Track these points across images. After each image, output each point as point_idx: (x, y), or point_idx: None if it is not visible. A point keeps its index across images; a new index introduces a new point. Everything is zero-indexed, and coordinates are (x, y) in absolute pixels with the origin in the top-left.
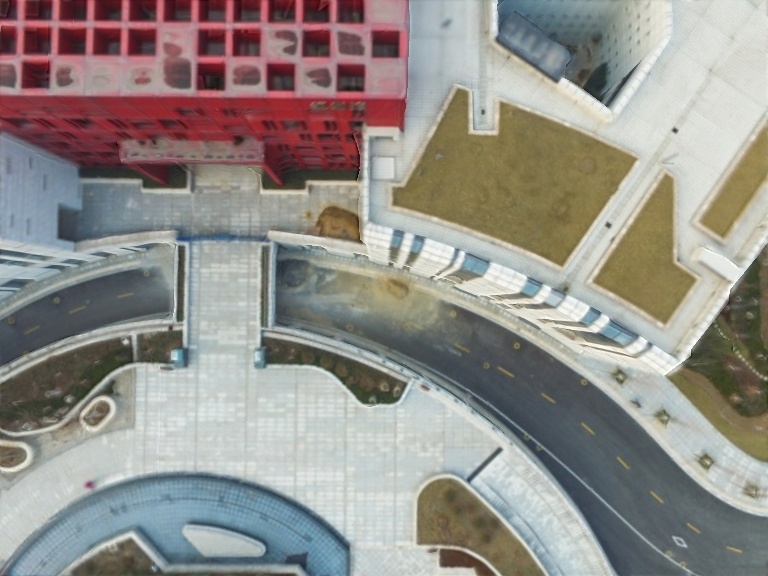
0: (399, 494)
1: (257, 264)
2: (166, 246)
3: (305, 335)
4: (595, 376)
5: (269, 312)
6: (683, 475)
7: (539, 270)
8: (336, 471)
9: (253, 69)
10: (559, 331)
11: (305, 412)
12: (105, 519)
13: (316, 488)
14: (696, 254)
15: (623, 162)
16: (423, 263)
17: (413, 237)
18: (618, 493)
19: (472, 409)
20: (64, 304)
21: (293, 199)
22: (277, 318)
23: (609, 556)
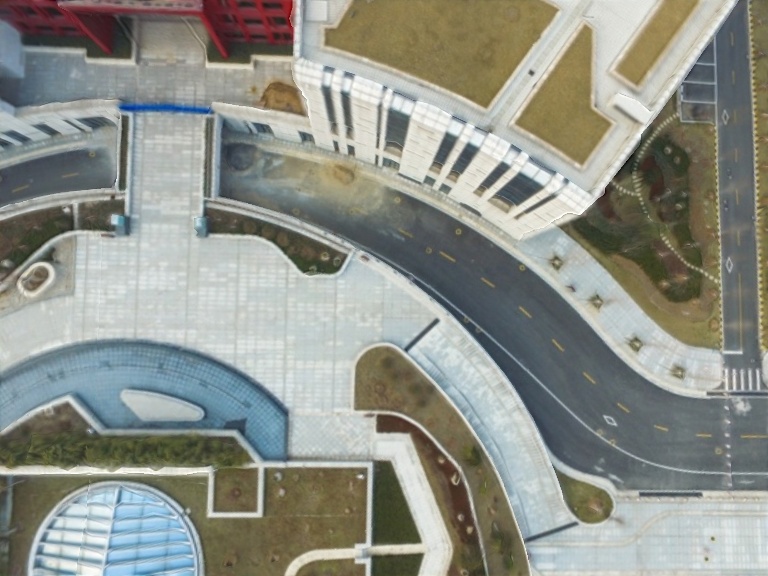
0: (338, 362)
1: (201, 136)
2: (112, 126)
3: (248, 206)
4: (533, 262)
5: (212, 183)
6: (614, 357)
7: (465, 113)
8: (276, 339)
9: None
10: (494, 204)
11: (247, 282)
12: (42, 385)
13: (256, 356)
14: (611, 99)
15: (545, 12)
16: (358, 117)
17: (343, 74)
18: (553, 374)
19: (410, 281)
20: (7, 183)
21: (238, 74)
22: (221, 193)
23: (543, 434)
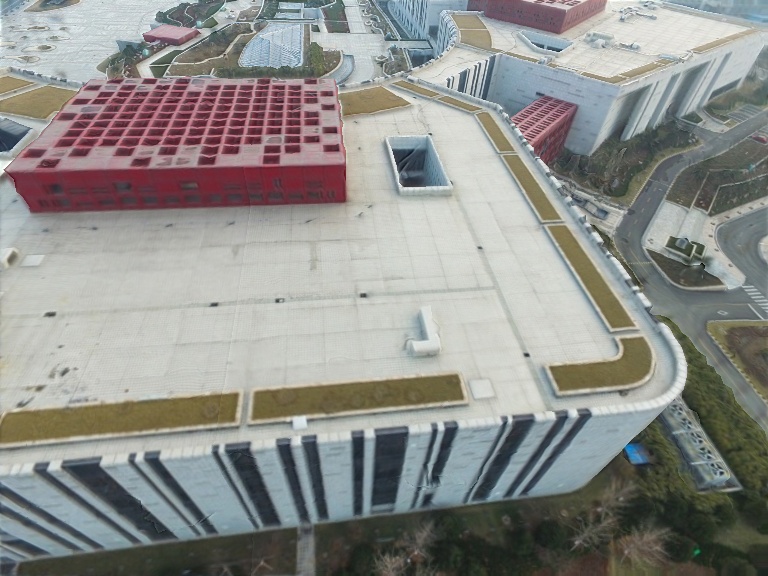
0: None
1: None
2: None
3: None
4: None
5: None
6: None
7: None
8: None
9: (162, 83)
10: None
11: None
12: None
13: None
14: None
15: None
16: None
17: None
18: None
19: None
20: None
21: None
22: None
23: None
